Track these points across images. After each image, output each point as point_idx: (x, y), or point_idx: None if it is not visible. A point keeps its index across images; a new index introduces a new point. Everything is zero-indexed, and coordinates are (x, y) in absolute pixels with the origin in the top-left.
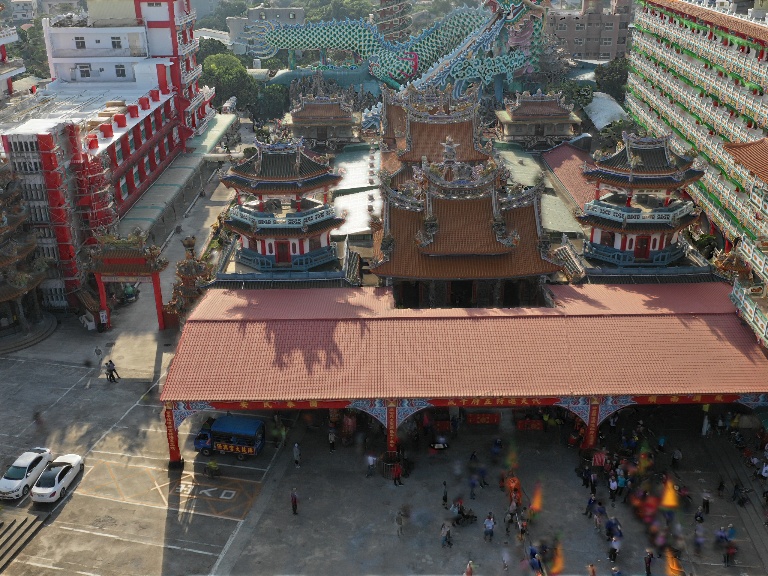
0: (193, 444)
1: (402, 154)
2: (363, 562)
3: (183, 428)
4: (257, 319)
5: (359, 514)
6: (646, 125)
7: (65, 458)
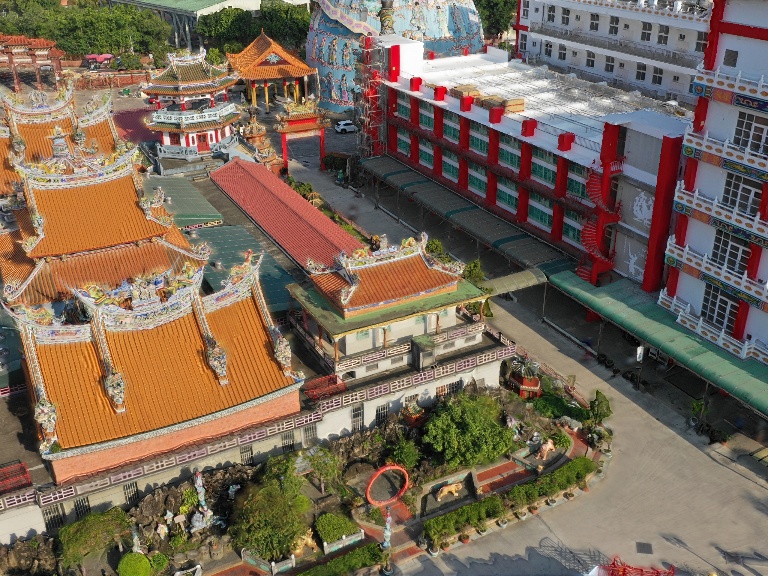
0: None
1: None
2: None
3: None
4: None
5: None
6: None
7: None
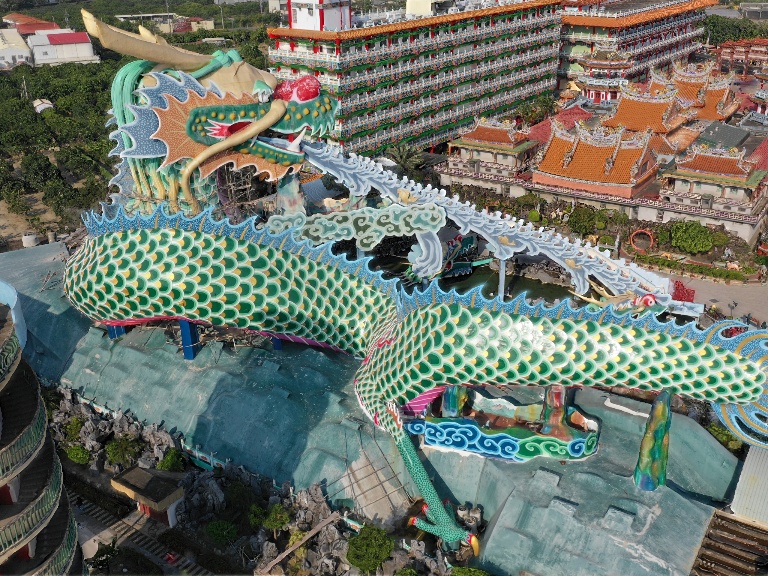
0: None
1: (683, 116)
2: None
3: None
4: None
5: None
6: None
7: None
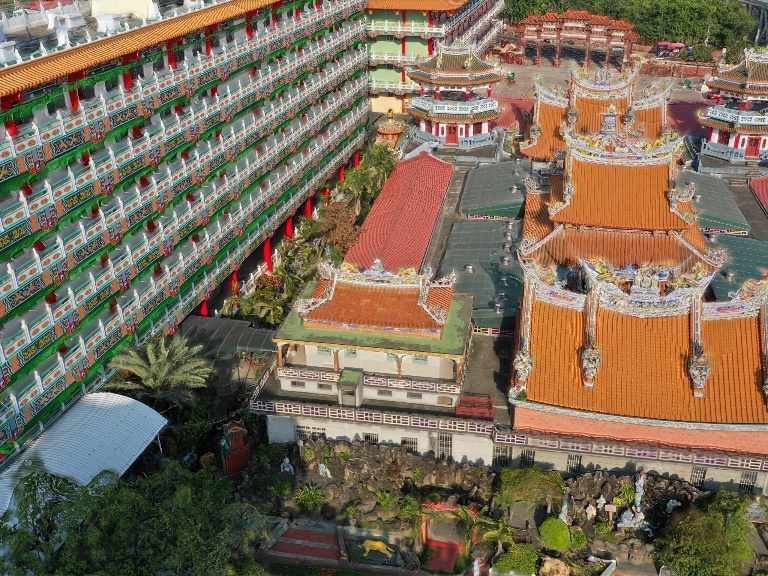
0: None
1: None
2: None
3: None
4: None
5: None
6: (164, 299)
7: None
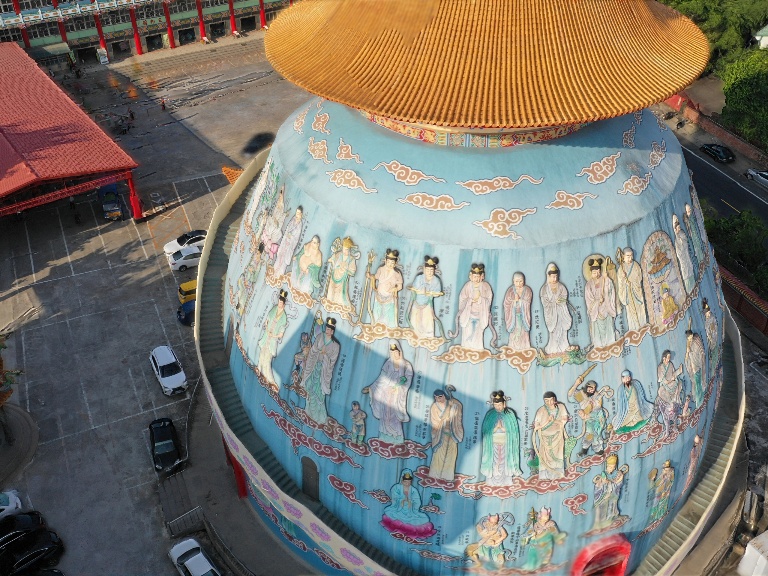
0: (113, 227)
1: None
2: (178, 146)
3: (95, 240)
4: (19, 157)
5: (143, 158)
6: None
7: (173, 247)
